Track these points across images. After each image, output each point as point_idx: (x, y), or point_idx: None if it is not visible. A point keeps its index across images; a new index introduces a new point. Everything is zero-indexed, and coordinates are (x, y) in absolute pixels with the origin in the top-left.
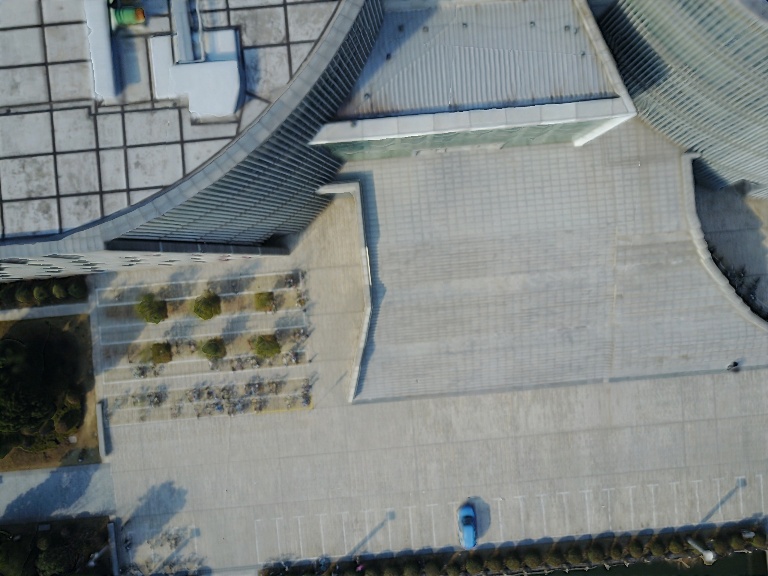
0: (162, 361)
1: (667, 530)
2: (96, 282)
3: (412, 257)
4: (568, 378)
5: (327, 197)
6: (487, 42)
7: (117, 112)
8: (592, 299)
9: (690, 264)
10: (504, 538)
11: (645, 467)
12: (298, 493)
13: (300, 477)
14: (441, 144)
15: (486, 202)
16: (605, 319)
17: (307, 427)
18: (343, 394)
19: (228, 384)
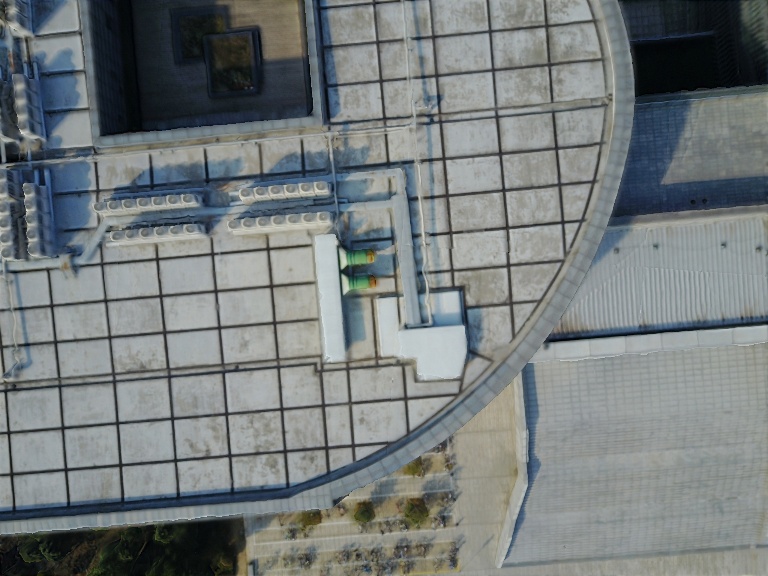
0: (312, 523)
1: None
2: None
3: (569, 435)
4: (715, 544)
5: None
6: (677, 264)
7: (342, 369)
8: (746, 473)
9: None
10: None
11: None
12: None
13: None
14: None
15: (645, 383)
16: (757, 491)
17: None
18: (490, 557)
19: (376, 546)
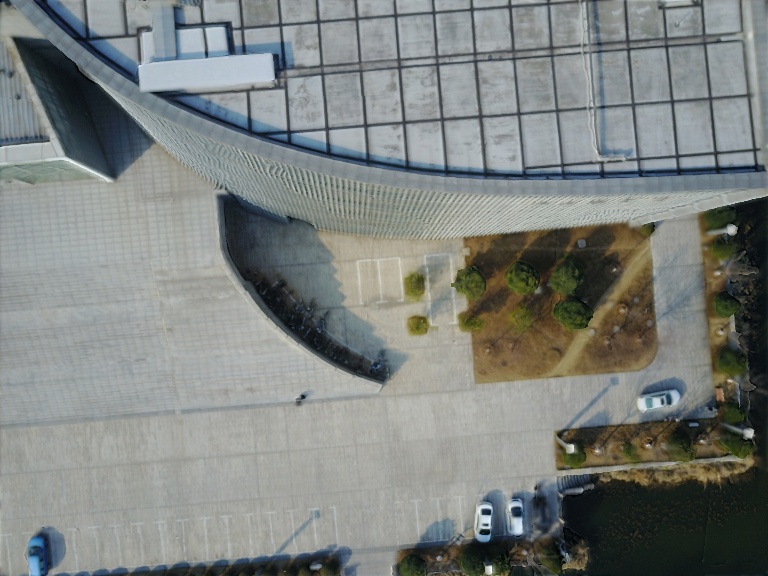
0: None
1: (242, 561)
2: None
3: None
4: (140, 410)
5: None
6: None
7: None
8: (144, 333)
9: (237, 299)
10: (79, 568)
11: (219, 498)
12: None
13: None
14: None
15: (20, 237)
16: (163, 352)
17: None
18: None
19: None
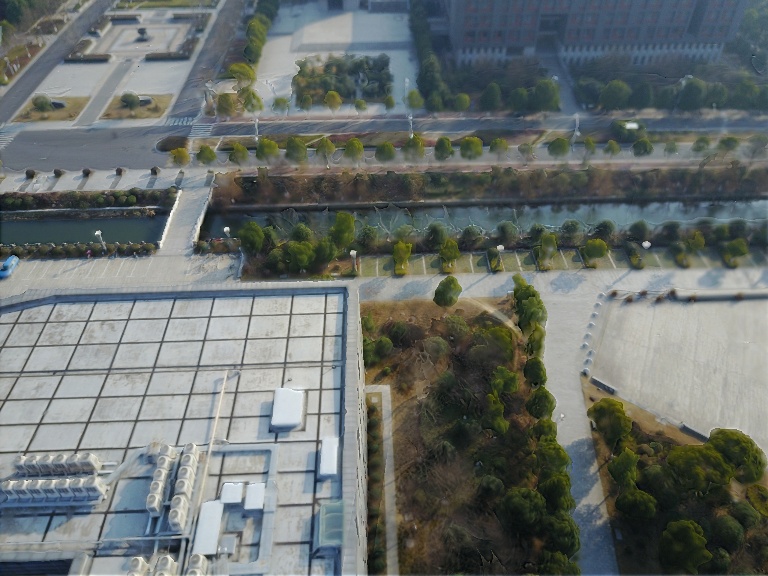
0: None
1: None
2: None
3: None
4: None
5: None
6: None
7: None
8: None
9: None
10: None
11: None
12: None
13: None
14: None
15: None
16: None
17: None
18: None
19: None
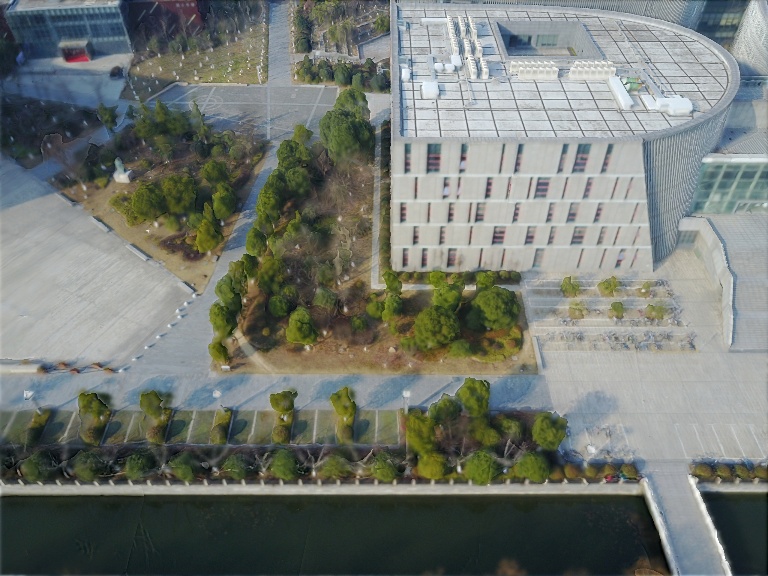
0: (577, 318)
1: None
2: (524, 277)
3: (750, 257)
4: None
5: (676, 239)
6: None
7: (631, 112)
8: None
9: None
10: None
11: None
12: (705, 408)
13: (703, 396)
14: (755, 197)
15: None
16: None
17: (698, 363)
18: (719, 345)
19: (629, 334)
